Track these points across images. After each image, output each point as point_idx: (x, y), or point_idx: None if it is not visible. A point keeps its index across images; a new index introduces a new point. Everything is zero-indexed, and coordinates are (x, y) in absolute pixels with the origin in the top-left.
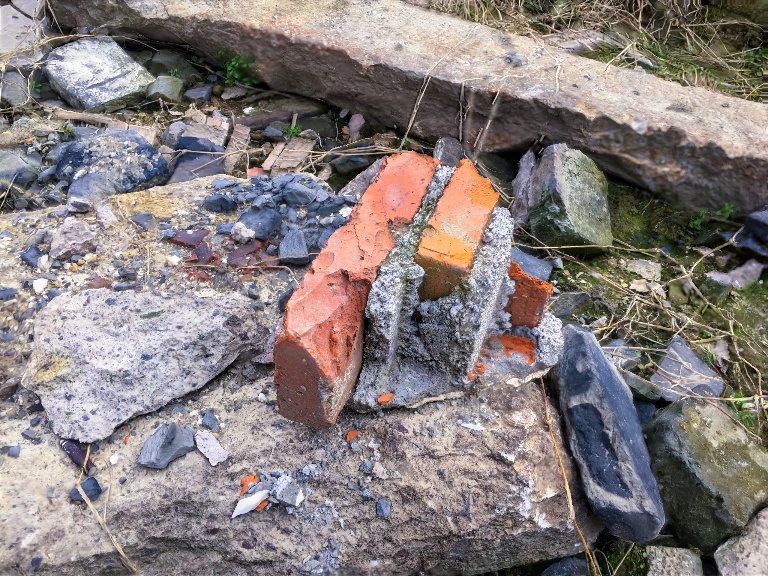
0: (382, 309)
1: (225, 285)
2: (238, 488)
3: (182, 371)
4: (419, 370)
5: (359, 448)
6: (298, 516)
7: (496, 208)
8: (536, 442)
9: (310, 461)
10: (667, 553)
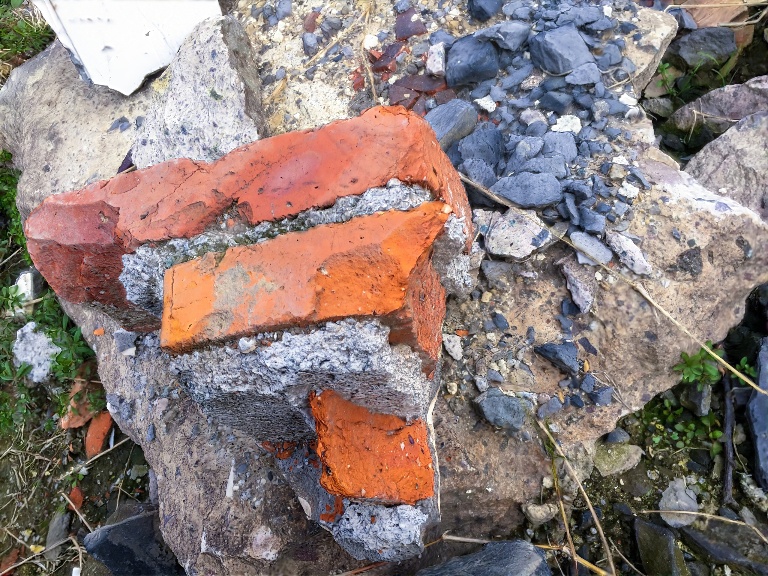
0: None
1: (356, 109)
2: None
3: None
4: None
5: None
6: None
7: (354, 321)
8: (247, 573)
9: None
10: None
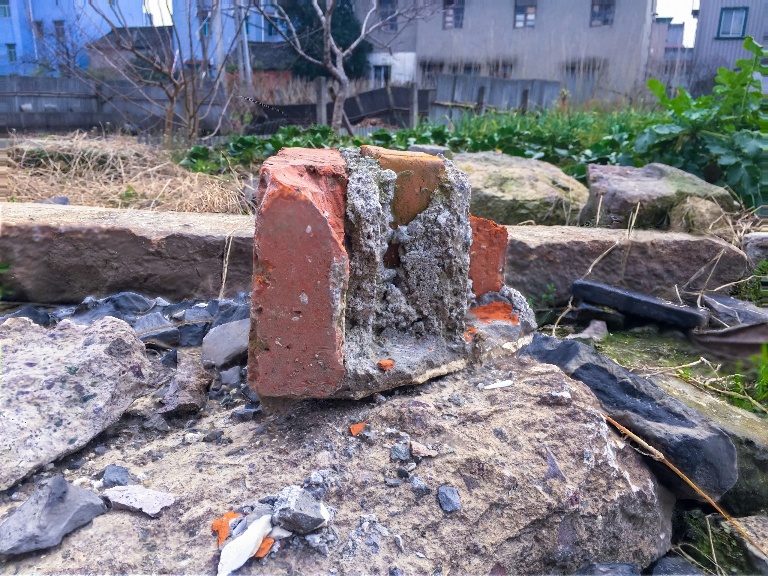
0: (368, 207)
1: None
2: (210, 540)
3: (48, 420)
4: (405, 342)
5: (376, 436)
6: (328, 551)
7: None
8: None
9: (314, 470)
10: (745, 521)
